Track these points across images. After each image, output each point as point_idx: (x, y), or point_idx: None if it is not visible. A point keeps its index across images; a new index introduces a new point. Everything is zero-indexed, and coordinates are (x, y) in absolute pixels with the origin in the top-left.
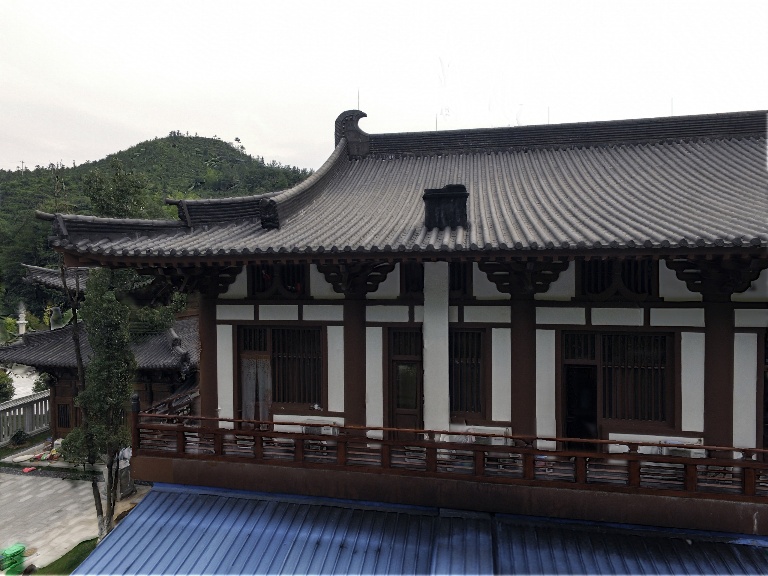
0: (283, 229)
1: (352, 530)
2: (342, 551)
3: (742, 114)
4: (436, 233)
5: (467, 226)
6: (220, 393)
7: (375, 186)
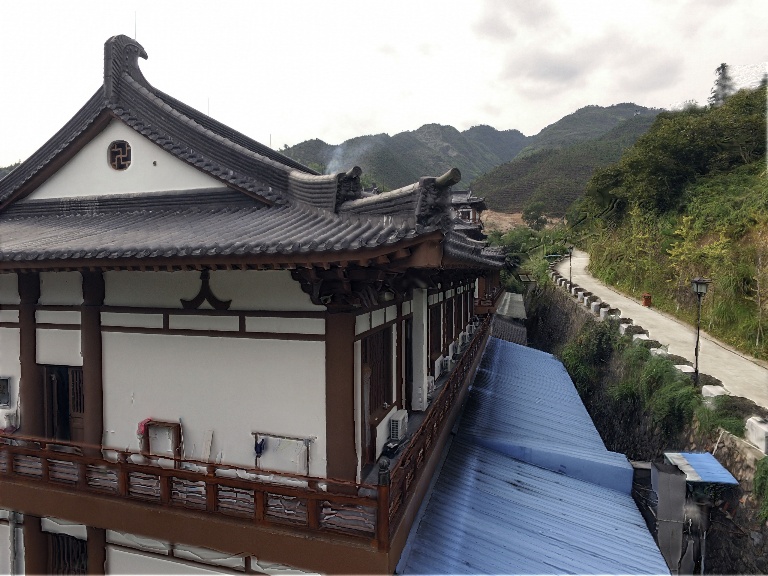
0: None
1: (465, 464)
2: (484, 472)
3: None
4: None
5: None
6: (356, 429)
7: None
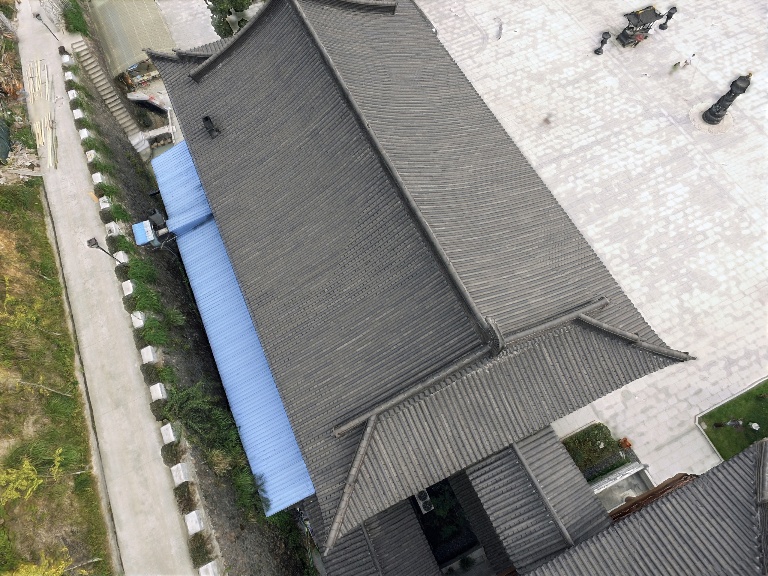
0: (201, 82)
1: None
2: None
3: (384, 162)
4: (202, 136)
5: (212, 138)
6: None
7: (262, 52)
